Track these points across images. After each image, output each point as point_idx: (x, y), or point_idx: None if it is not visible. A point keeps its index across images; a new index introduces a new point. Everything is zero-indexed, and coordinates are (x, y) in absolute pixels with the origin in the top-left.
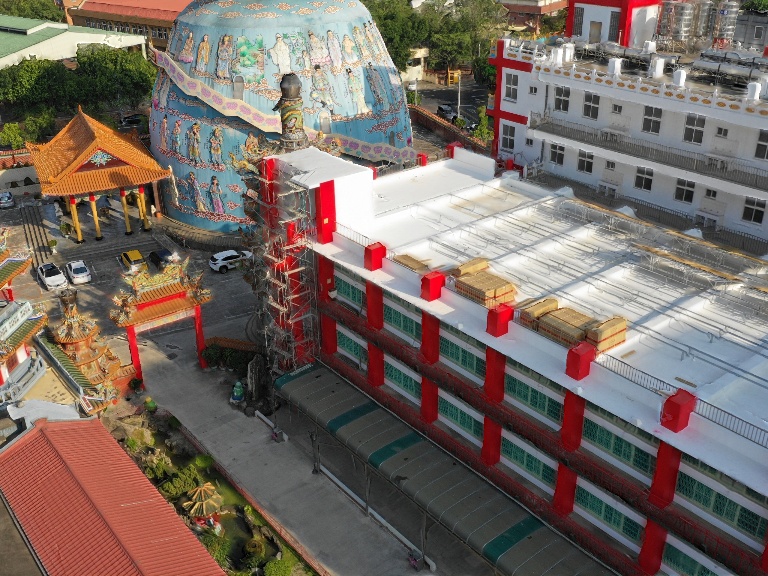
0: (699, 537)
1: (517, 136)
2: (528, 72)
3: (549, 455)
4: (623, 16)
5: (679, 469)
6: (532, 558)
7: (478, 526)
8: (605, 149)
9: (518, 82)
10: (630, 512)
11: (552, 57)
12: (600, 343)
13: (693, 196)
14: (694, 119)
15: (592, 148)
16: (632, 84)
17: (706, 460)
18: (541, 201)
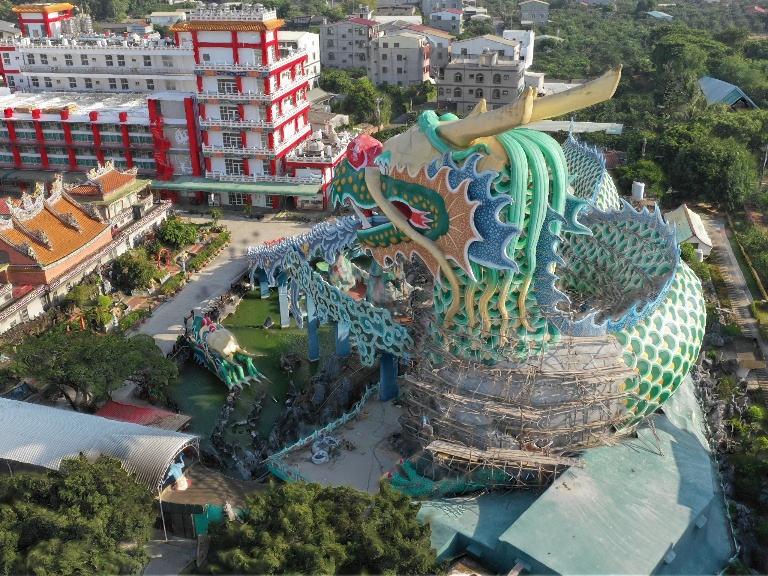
0: (109, 146)
1: (15, 79)
2: (13, 51)
3: (65, 154)
4: (46, 26)
5: (100, 134)
6: (68, 177)
7: (49, 177)
8: (55, 73)
9: (9, 56)
10: (93, 157)
11: (22, 43)
12: (69, 109)
13: (92, 85)
14: (84, 57)
15: (50, 74)
16: (57, 47)
17: (103, 122)
18: (36, 96)
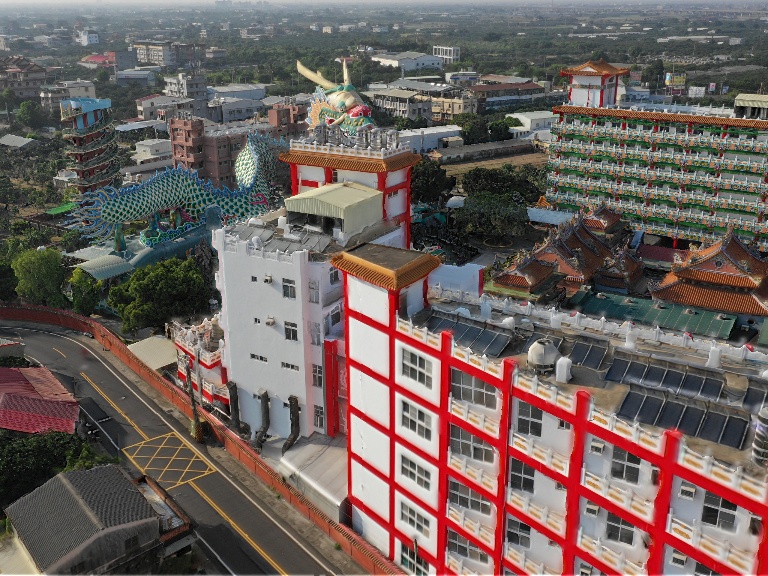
0: None
1: None
2: None
3: None
4: None
5: None
6: None
7: None
8: None
9: None
10: None
11: None
12: None
13: None
14: None
15: None
16: None
17: None
18: None
